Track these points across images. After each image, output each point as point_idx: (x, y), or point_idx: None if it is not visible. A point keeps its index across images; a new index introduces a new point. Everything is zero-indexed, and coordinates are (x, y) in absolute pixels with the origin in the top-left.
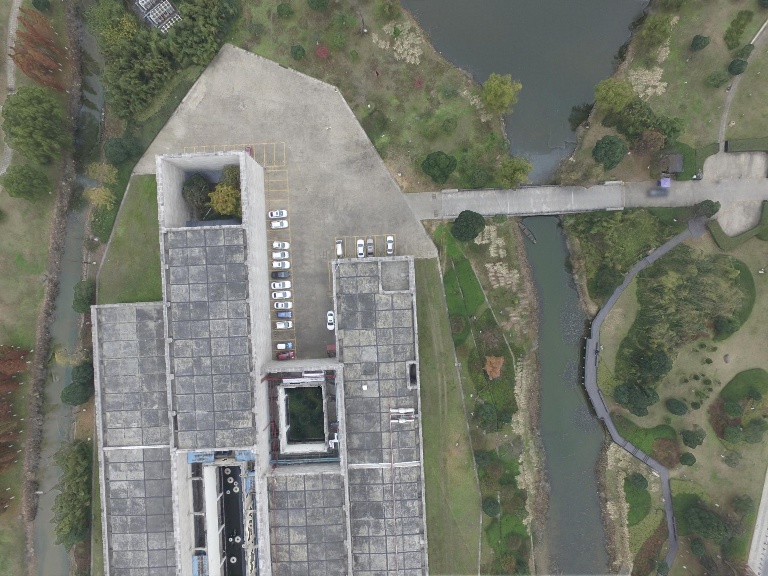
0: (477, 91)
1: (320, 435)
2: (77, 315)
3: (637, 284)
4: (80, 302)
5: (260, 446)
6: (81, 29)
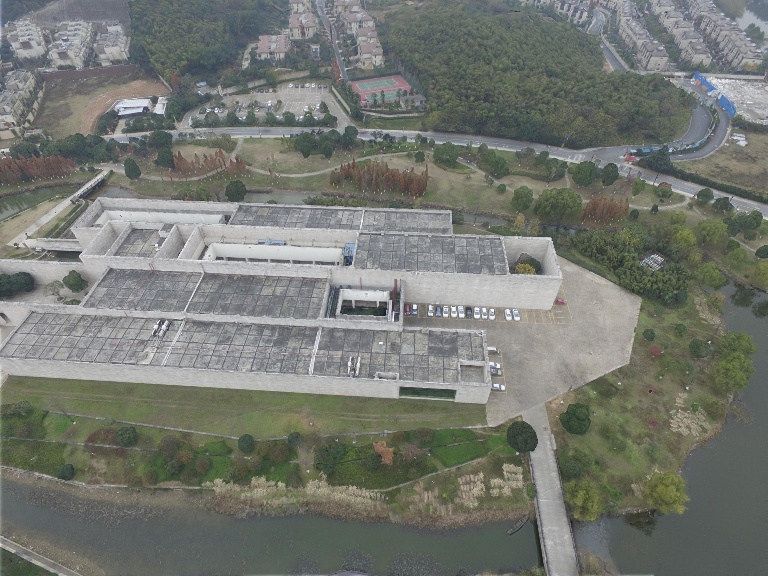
0: None
1: None
2: None
3: None
4: None
5: (352, 271)
6: None
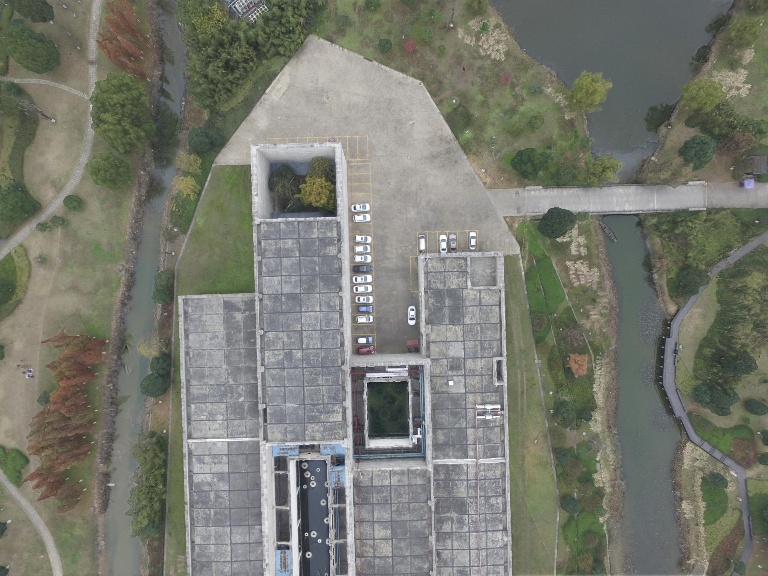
0: (561, 89)
1: (399, 430)
2: (153, 306)
3: (717, 284)
4: (161, 293)
5: (350, 440)
6: (162, 17)
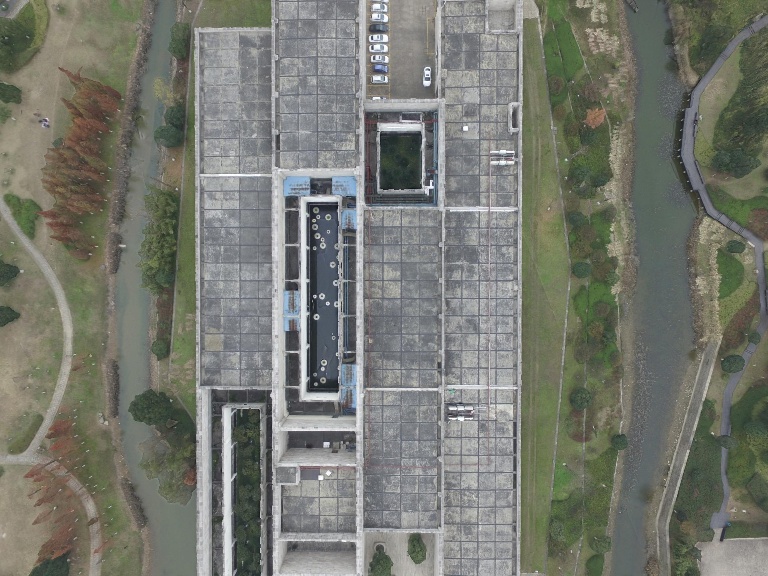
0: None
1: None
2: (168, 68)
3: (740, 53)
4: (177, 42)
5: (362, 170)
6: None
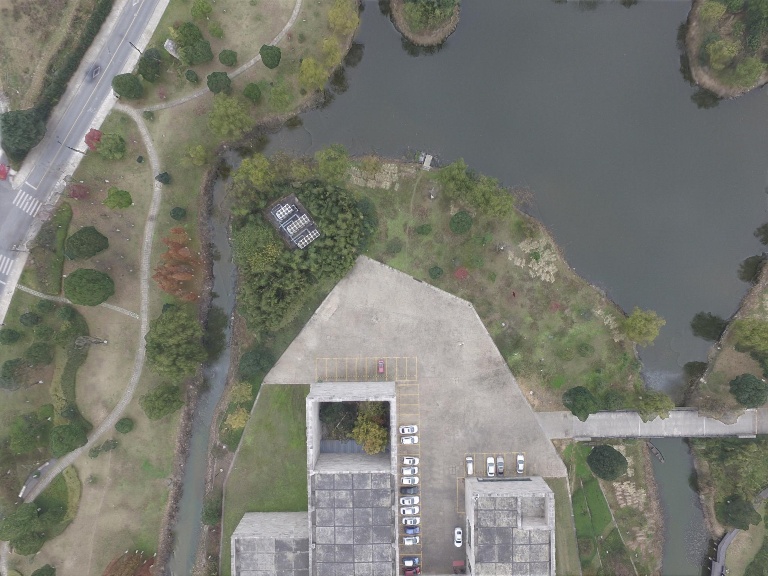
0: (610, 310)
1: None
2: (200, 518)
3: (765, 509)
4: (210, 516)
5: None
6: (213, 232)
